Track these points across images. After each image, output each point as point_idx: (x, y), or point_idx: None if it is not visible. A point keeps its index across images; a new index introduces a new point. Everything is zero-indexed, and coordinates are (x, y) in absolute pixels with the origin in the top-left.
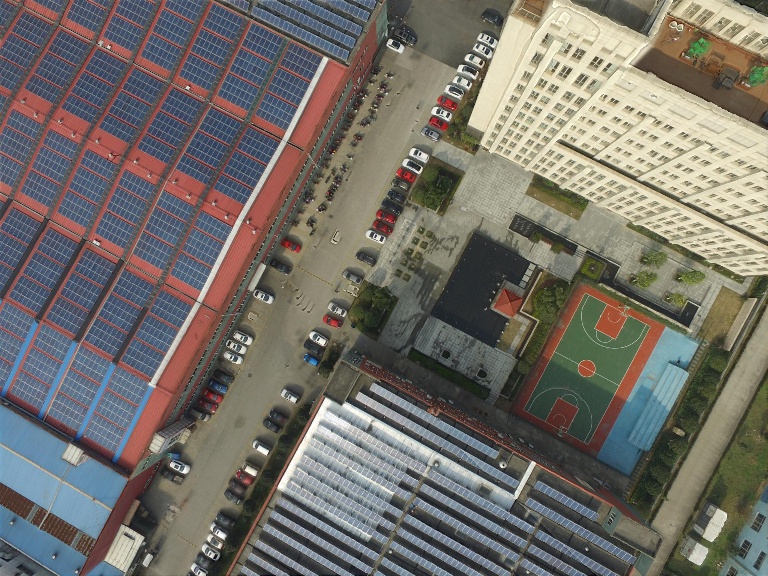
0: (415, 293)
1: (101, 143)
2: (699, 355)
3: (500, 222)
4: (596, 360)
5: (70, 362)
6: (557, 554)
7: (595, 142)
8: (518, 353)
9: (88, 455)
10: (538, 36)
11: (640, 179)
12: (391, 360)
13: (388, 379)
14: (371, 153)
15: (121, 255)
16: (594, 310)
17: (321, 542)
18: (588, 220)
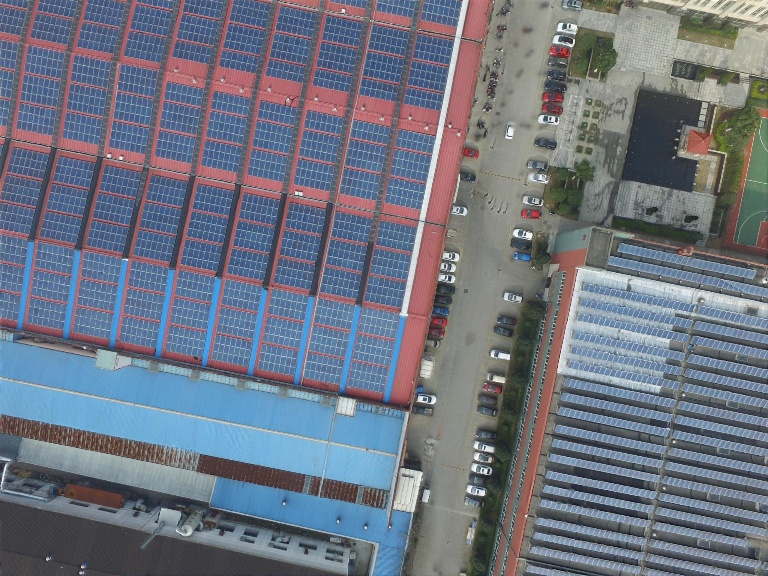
0: (601, 164)
1: (273, 90)
2: None
3: (661, 72)
4: None
5: (312, 319)
6: None
7: None
8: (715, 190)
9: (361, 402)
10: None
11: None
12: None
13: None
14: (518, 40)
15: (328, 198)
16: None
17: (617, 407)
18: (742, 47)
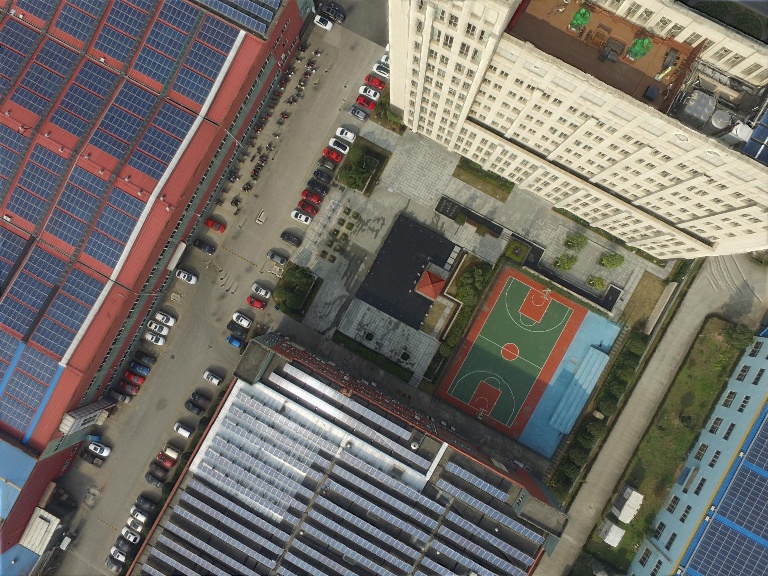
0: (340, 275)
1: (11, 115)
2: (621, 339)
3: (426, 204)
4: (519, 343)
5: None
6: (467, 535)
7: (502, 119)
8: (441, 336)
9: None
10: (414, 2)
11: (549, 158)
12: (315, 342)
13: (304, 360)
14: (298, 132)
15: (32, 231)
16: (518, 293)
17: (231, 523)
18: (514, 203)
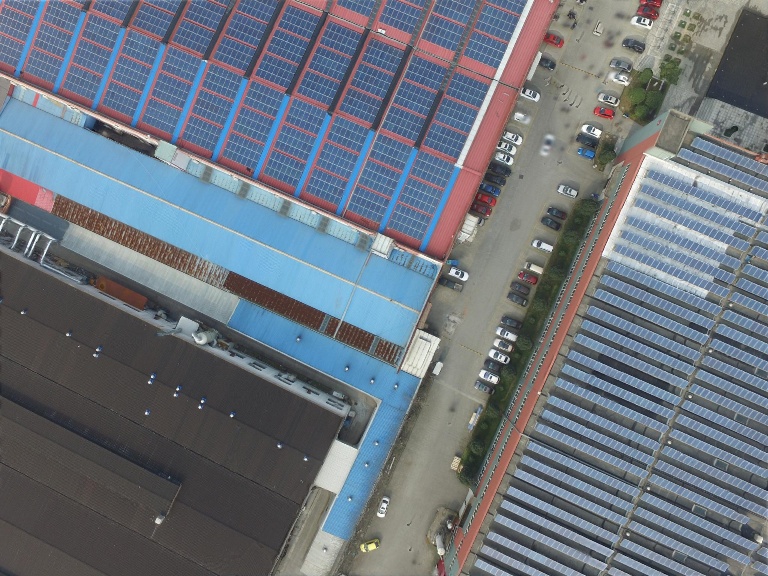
0: (687, 77)
1: None
2: None
3: None
4: None
5: (368, 153)
6: None
7: None
8: None
9: (398, 243)
10: None
11: None
12: None
13: None
14: None
15: (408, 41)
16: None
17: (658, 302)
18: None
